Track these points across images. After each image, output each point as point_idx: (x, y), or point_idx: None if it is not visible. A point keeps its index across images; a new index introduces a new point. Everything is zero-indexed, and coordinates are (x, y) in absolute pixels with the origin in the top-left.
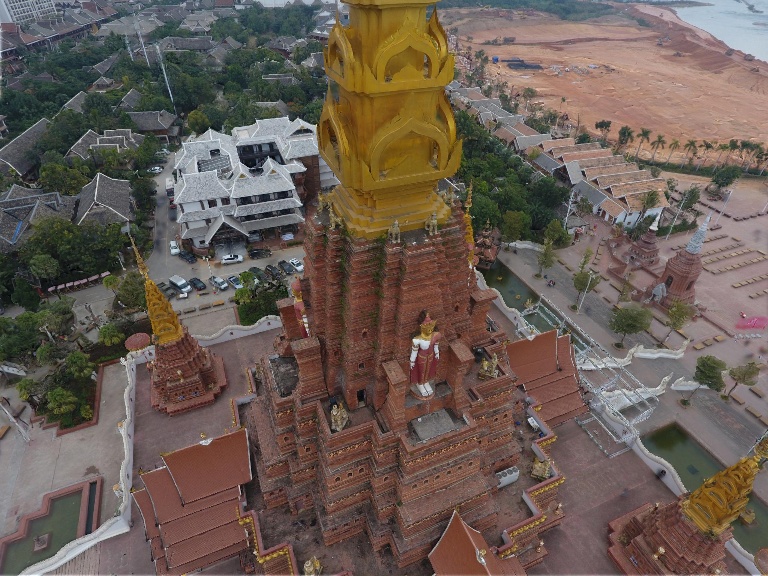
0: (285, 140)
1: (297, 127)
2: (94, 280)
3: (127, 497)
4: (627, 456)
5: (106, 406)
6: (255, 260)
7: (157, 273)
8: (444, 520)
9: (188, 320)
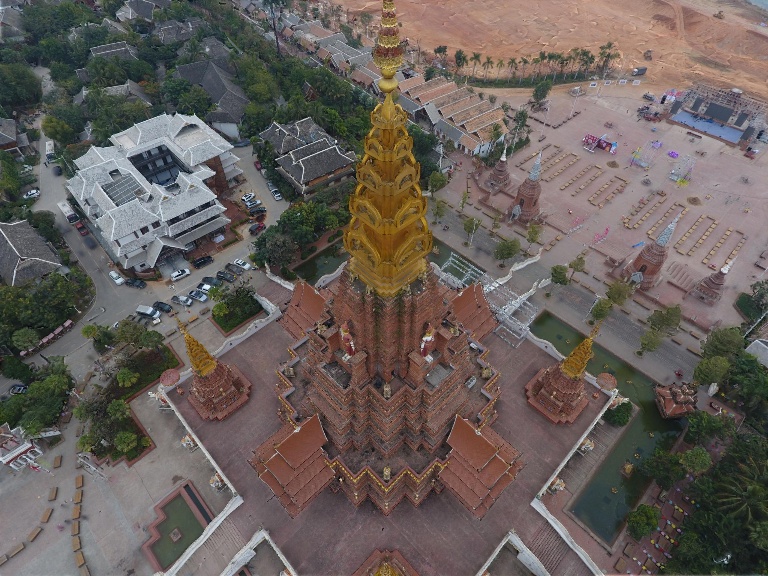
0: (174, 141)
1: (181, 125)
2: (60, 332)
3: (230, 483)
4: (525, 343)
5: (153, 432)
6: (201, 269)
7: (115, 307)
8: (449, 421)
9: (175, 341)
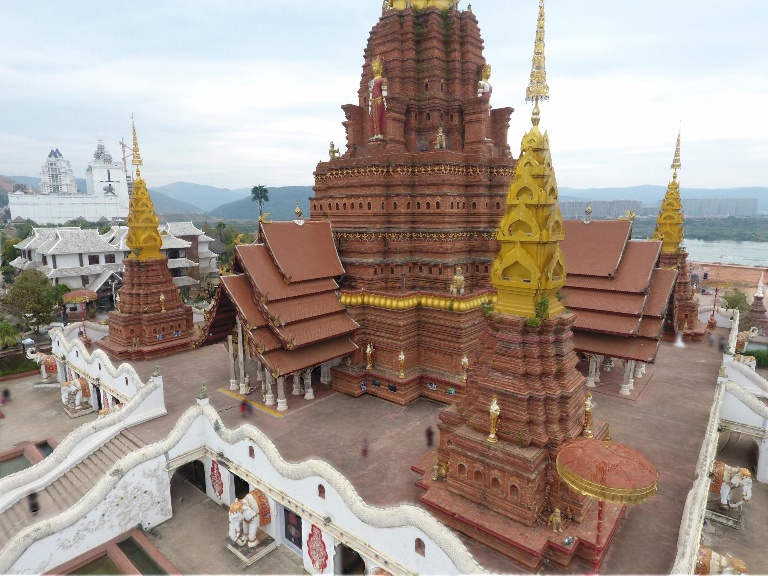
0: None
1: None
2: None
3: None
4: None
5: (8, 406)
6: None
7: None
8: None
9: None
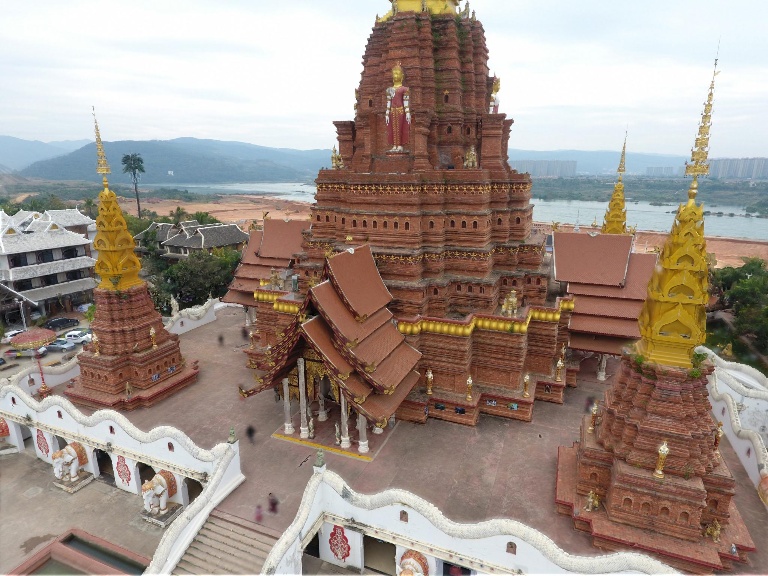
0: None
1: (29, 215)
2: None
3: None
4: None
5: None
6: (58, 331)
7: None
8: None
9: None
